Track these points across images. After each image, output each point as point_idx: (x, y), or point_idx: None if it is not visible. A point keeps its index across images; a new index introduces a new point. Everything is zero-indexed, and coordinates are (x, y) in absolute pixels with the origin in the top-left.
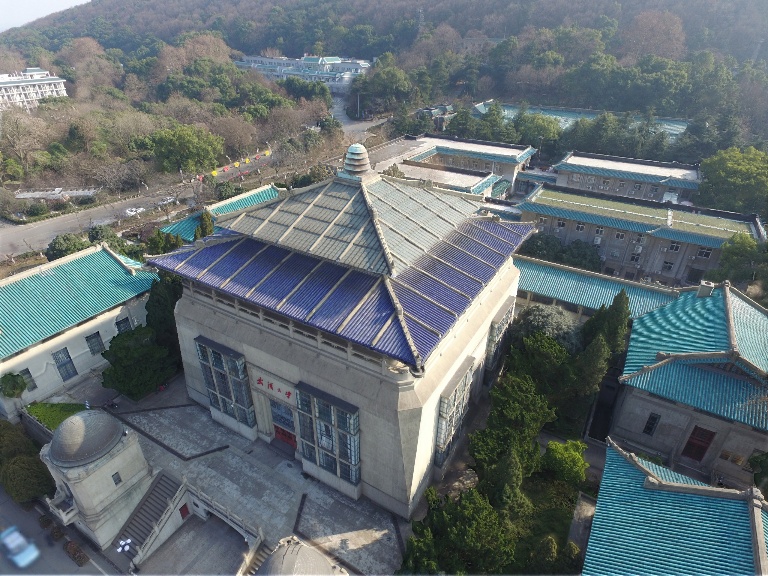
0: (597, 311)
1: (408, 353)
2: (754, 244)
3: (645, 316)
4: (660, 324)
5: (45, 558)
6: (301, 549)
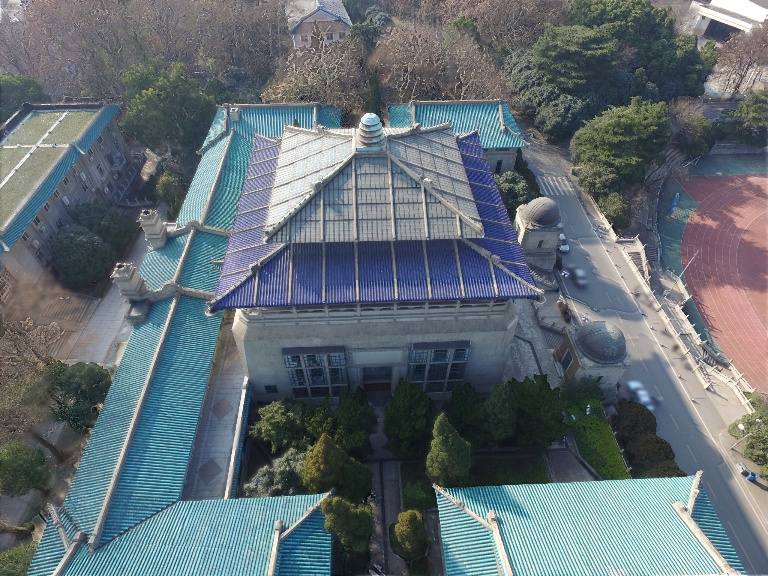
0: None
1: (475, 135)
2: (158, 91)
3: None
4: None
5: (624, 382)
6: (536, 204)
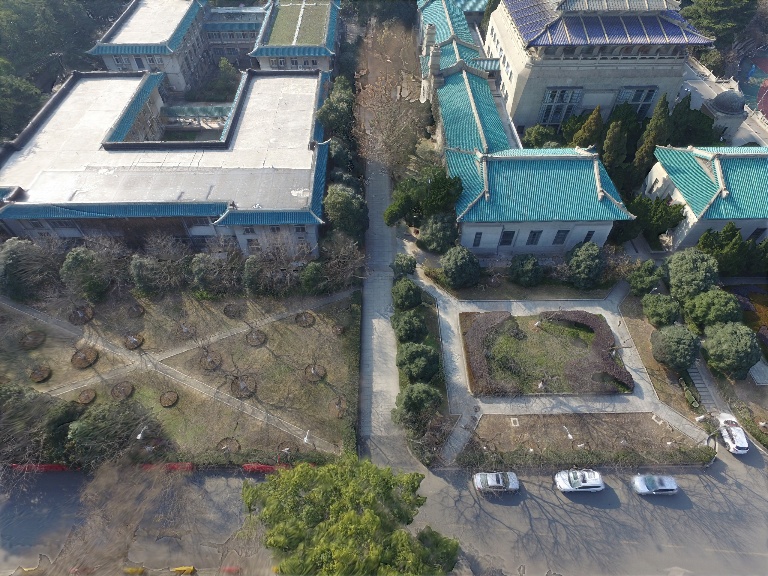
0: (494, 2)
1: None
2: None
3: (461, 7)
4: (470, 1)
5: None
6: None
